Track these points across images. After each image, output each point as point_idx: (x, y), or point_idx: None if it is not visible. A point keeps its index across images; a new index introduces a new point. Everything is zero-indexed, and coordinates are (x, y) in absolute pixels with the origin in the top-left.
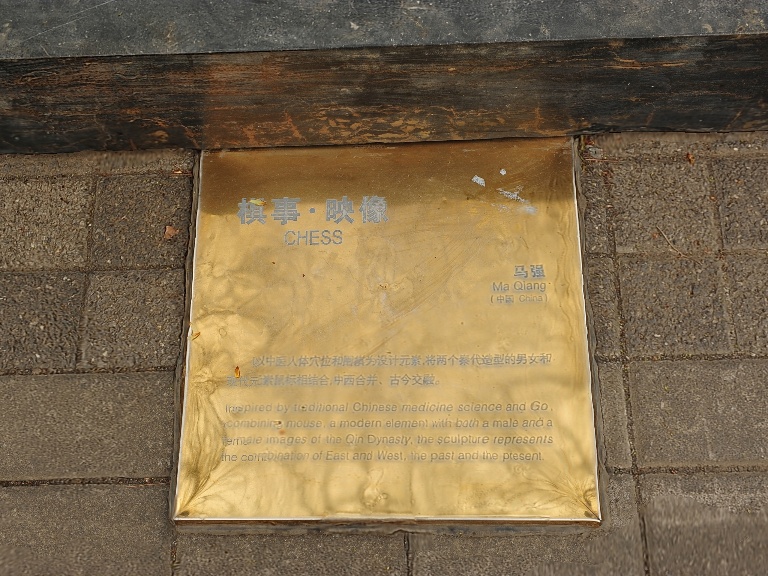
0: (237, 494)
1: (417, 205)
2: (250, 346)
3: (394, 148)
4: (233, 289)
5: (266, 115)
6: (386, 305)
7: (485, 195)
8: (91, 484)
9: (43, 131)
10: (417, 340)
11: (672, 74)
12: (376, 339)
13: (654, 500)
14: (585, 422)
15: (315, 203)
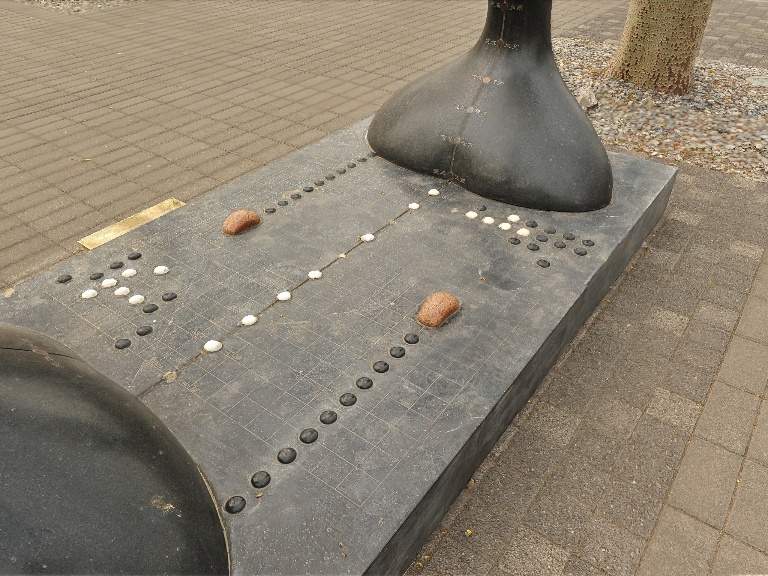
0: (164, 205)
1: None
2: None
3: None
4: None
5: None
6: None
7: None
8: (198, 195)
9: None
10: None
11: None
12: None
13: None
14: None
15: None
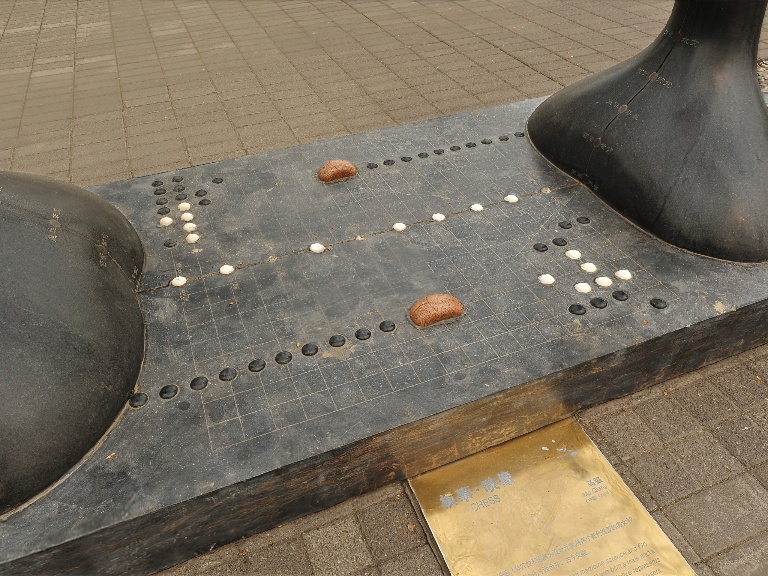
0: None
1: (524, 470)
2: (487, 571)
3: (499, 447)
4: (462, 543)
5: (445, 445)
6: (540, 523)
7: (552, 454)
8: None
9: (333, 492)
10: (566, 535)
11: (613, 370)
12: (546, 542)
13: (723, 572)
14: (668, 544)
15: (477, 486)
